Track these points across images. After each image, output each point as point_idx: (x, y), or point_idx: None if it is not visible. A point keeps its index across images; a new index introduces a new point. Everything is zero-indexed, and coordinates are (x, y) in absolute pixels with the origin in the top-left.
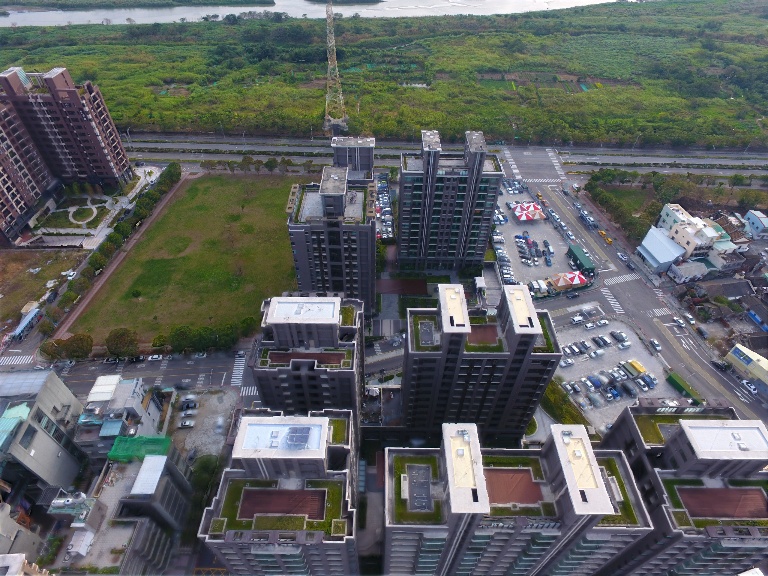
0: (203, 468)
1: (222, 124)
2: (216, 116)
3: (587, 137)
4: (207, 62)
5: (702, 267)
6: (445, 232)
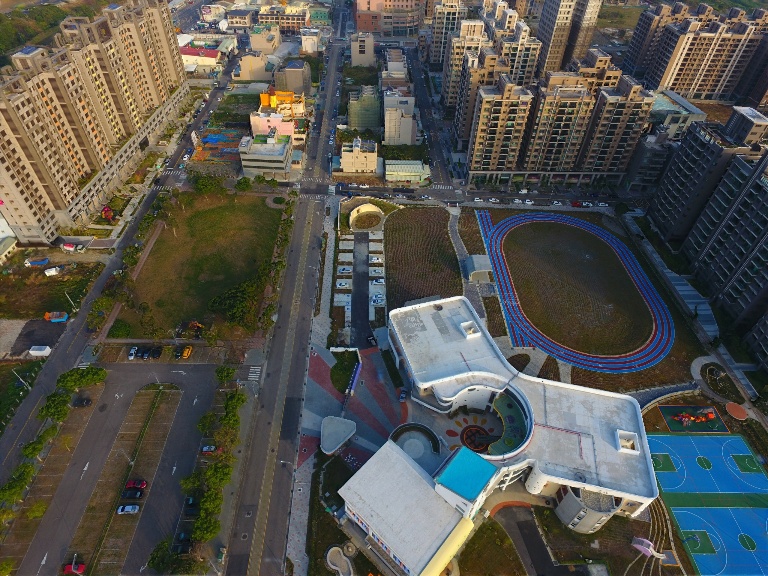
0: None
1: None
2: None
3: None
4: None
5: None
6: None
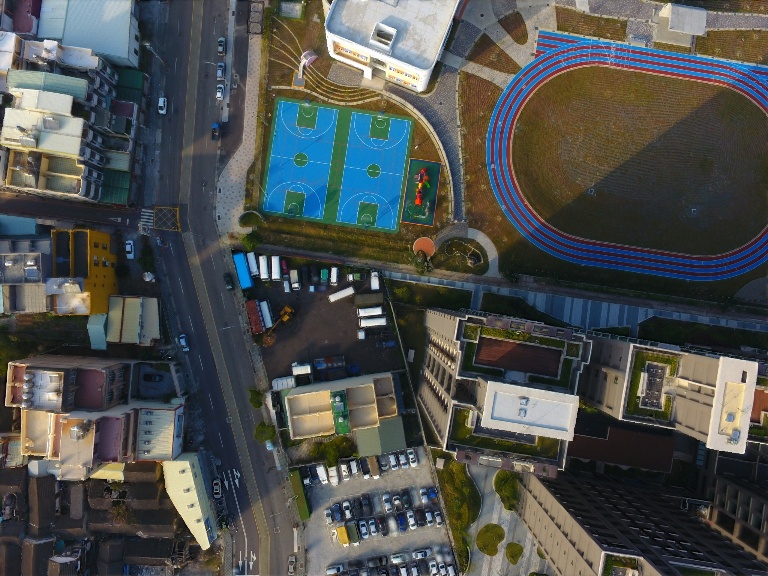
0: None
1: None
2: None
3: None
4: None
5: None
6: None
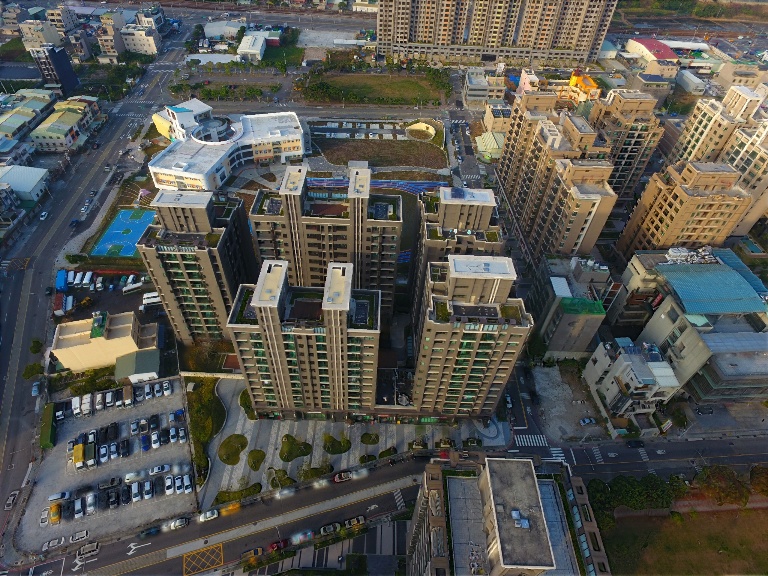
0: None
1: None
2: None
3: None
4: None
5: None
6: None
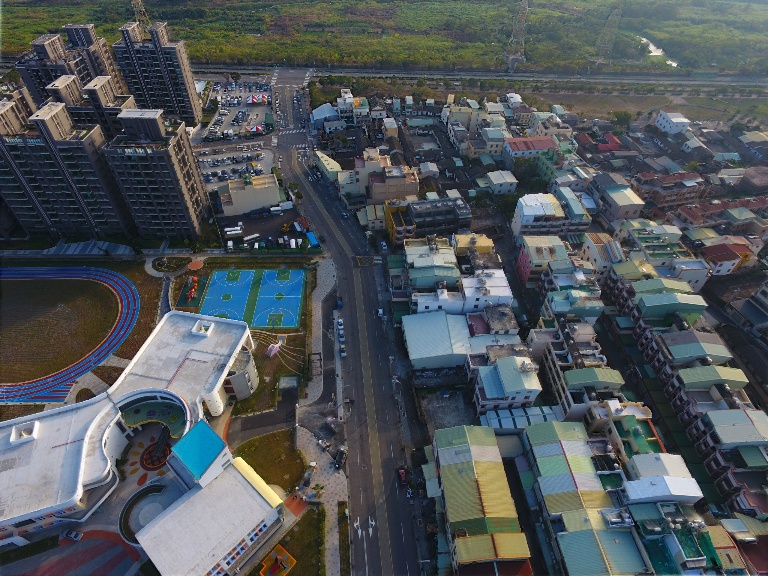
0: None
1: None
2: None
3: (338, 60)
4: (90, 18)
5: (342, 122)
6: (159, 94)
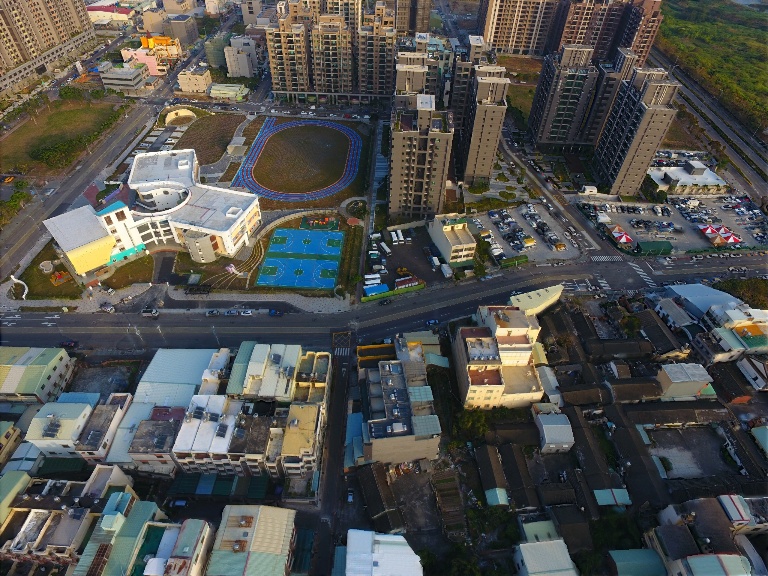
0: (438, 103)
1: (727, 96)
2: (738, 93)
3: None
4: None
5: (683, 319)
6: None
